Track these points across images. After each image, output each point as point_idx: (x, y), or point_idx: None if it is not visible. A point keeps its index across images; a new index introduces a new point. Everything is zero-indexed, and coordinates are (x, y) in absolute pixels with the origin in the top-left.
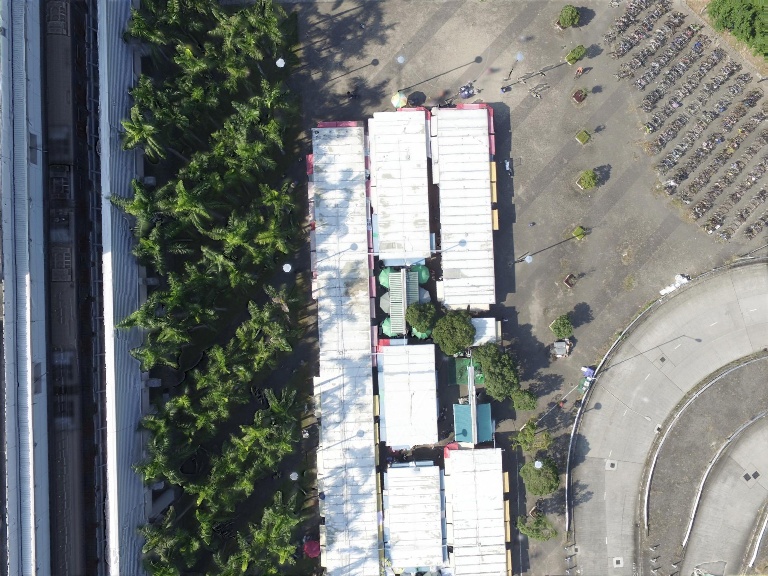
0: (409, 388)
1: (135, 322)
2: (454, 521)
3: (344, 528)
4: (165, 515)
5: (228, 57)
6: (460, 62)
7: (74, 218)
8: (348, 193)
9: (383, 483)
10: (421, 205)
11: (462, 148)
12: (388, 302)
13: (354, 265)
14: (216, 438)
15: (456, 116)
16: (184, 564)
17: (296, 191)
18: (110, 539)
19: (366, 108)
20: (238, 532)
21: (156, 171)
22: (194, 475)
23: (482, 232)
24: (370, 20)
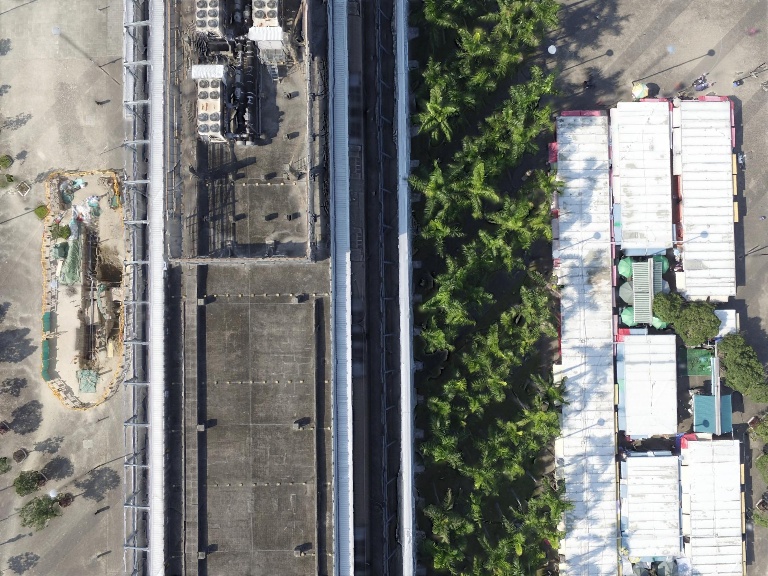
0: (650, 378)
1: (441, 303)
2: (692, 511)
3: (583, 516)
4: (445, 497)
5: (500, 43)
6: (693, 55)
7: (364, 198)
8: (592, 182)
9: (620, 472)
10: (664, 196)
11: (704, 140)
12: (630, 292)
13: (597, 254)
14: (481, 422)
15: (699, 108)
16: (456, 547)
17: (530, 179)
18: (404, 519)
19: (600, 98)
20: (504, 516)
21: (417, 155)
22: (466, 458)
23: (723, 224)
24: (605, 11)
